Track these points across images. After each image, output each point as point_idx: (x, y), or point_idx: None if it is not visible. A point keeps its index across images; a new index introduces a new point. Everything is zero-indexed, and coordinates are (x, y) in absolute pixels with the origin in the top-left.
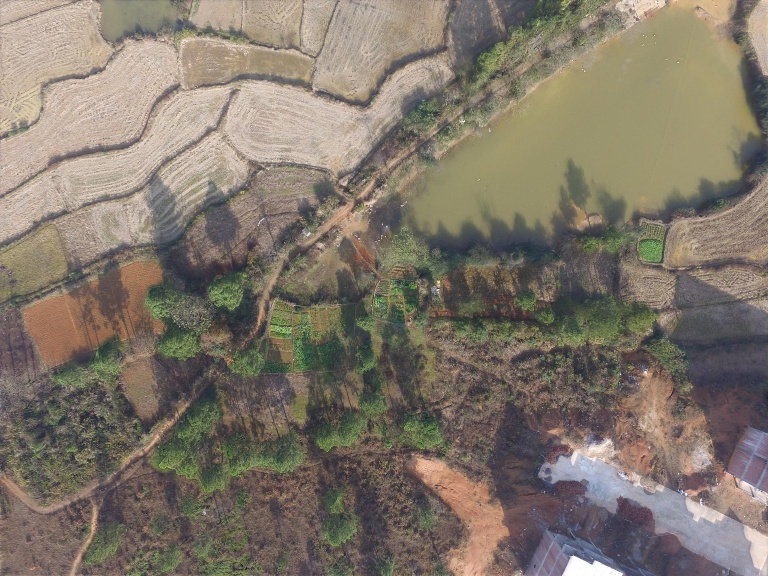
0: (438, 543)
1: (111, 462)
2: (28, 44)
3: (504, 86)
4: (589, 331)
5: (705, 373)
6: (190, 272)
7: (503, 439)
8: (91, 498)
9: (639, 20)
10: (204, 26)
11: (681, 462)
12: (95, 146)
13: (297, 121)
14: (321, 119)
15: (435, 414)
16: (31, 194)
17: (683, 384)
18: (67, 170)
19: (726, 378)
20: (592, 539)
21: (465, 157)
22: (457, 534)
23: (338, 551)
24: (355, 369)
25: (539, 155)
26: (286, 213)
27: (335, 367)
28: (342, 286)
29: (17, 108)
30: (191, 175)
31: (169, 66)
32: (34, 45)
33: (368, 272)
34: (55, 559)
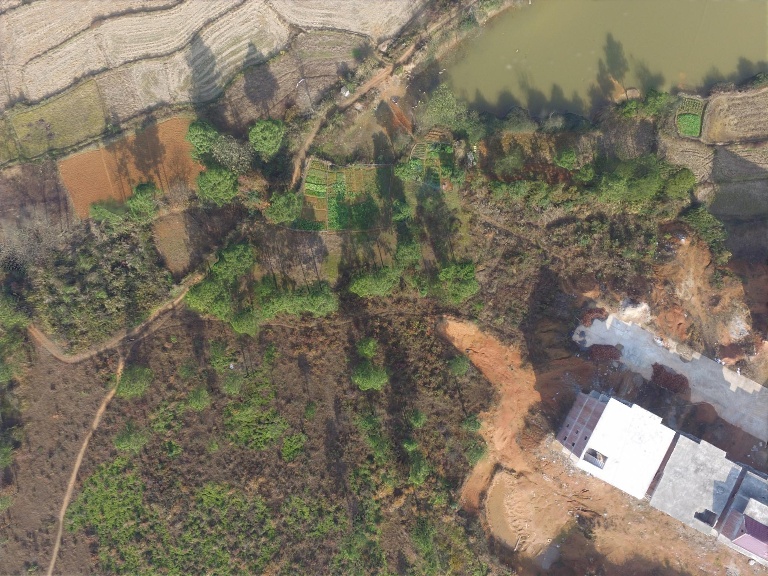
0: (468, 406)
1: (140, 311)
2: None
3: None
4: (628, 191)
5: (743, 247)
6: (227, 130)
7: (537, 302)
8: (118, 348)
9: None
10: None
11: (718, 332)
12: (138, 7)
13: None
14: None
15: None
16: (73, 51)
17: (721, 253)
18: (110, 29)
19: (764, 252)
20: None
21: (504, 28)
22: (488, 397)
23: (366, 410)
24: (389, 230)
25: (578, 29)
26: (325, 75)
27: (369, 227)
28: (378, 149)
29: None
30: (232, 37)
31: None
32: None
33: (405, 134)
34: (79, 408)
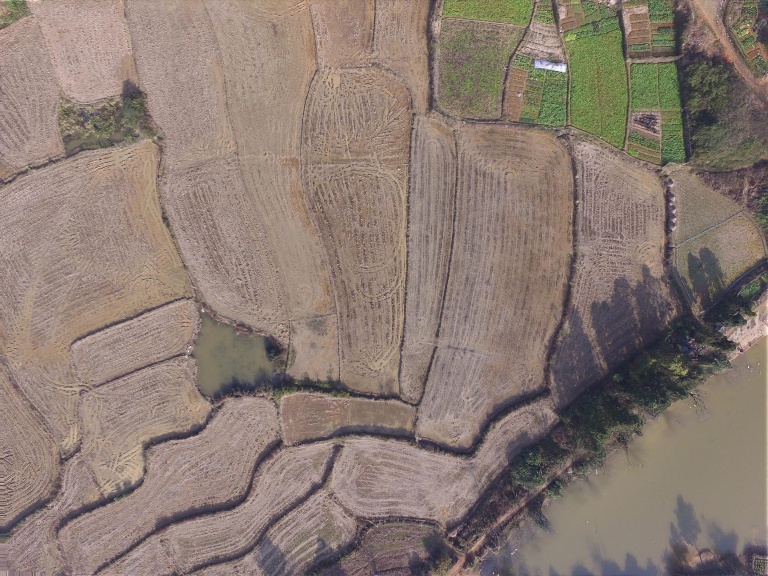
0: None
1: None
2: (126, 404)
3: (612, 436)
4: None
5: None
6: None
7: None
8: None
9: (743, 350)
10: (302, 377)
11: None
12: (201, 505)
13: (402, 474)
14: (426, 470)
15: None
16: (141, 558)
17: None
18: (175, 533)
19: None
20: None
21: (573, 501)
22: None
23: None
24: None
25: (647, 494)
26: (397, 569)
27: None
28: None
29: (120, 469)
30: (299, 533)
31: (269, 421)
32: (132, 404)
33: None
34: None
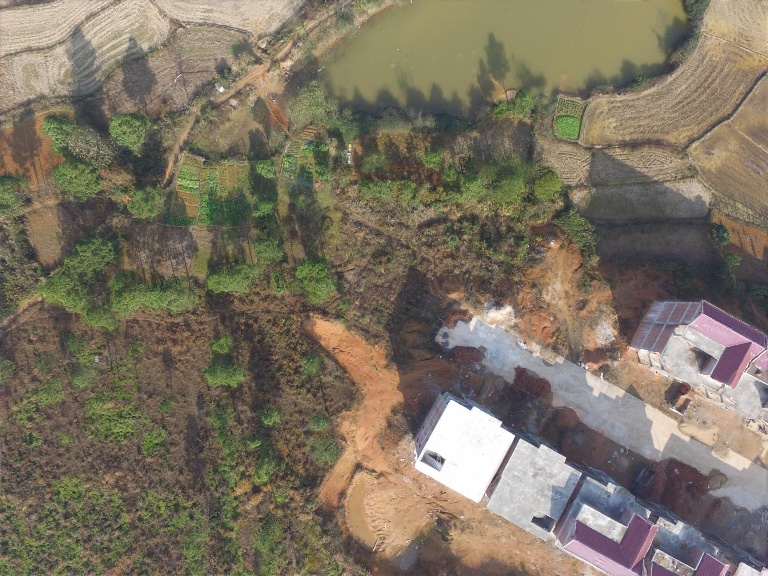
0: (331, 405)
1: (7, 303)
2: None
3: None
4: (493, 192)
5: (616, 252)
6: (104, 124)
7: (403, 303)
8: None
9: None
10: None
11: (584, 336)
12: None
13: None
14: None
15: (337, 275)
16: None
17: (590, 257)
18: None
19: (637, 257)
20: (486, 407)
21: (385, 26)
22: (350, 397)
23: (228, 406)
24: (260, 227)
25: (460, 28)
26: (203, 71)
27: (240, 224)
28: (254, 146)
29: None
30: (113, 31)
31: None
32: None
33: (279, 131)
34: None
